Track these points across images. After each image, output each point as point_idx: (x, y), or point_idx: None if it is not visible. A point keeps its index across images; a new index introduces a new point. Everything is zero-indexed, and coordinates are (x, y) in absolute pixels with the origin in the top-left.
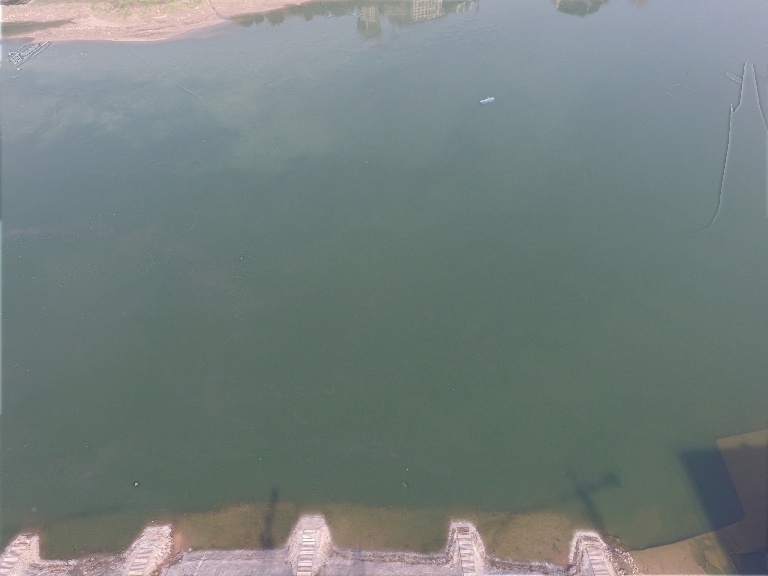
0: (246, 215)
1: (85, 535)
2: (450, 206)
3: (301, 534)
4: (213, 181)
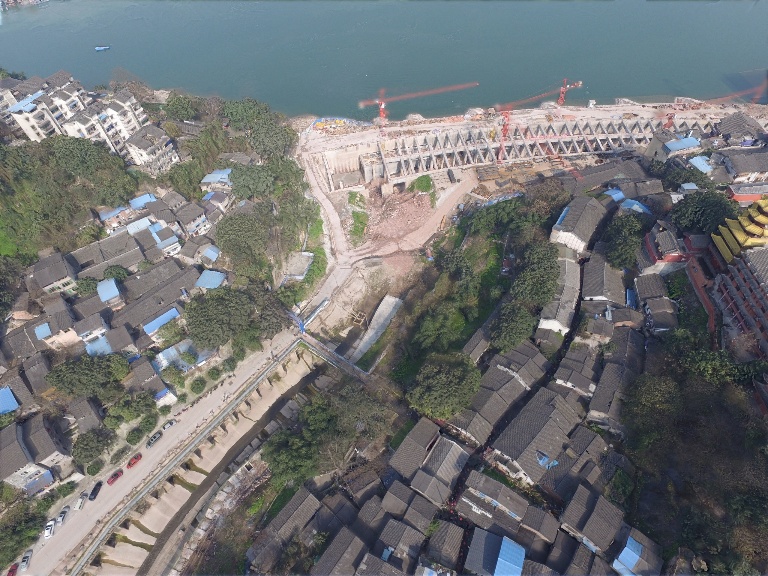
0: (448, 17)
1: (440, 113)
2: (567, 10)
3: (546, 103)
4: (417, 7)
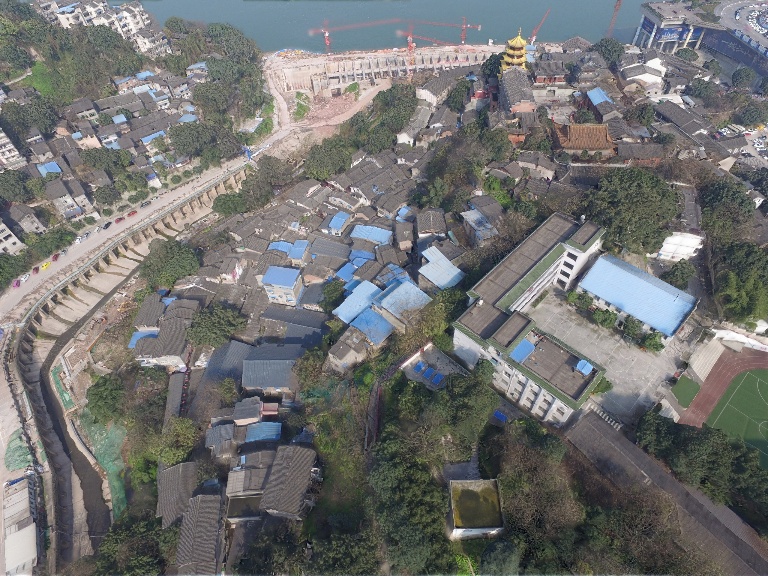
0: None
1: None
2: None
3: None
4: None
